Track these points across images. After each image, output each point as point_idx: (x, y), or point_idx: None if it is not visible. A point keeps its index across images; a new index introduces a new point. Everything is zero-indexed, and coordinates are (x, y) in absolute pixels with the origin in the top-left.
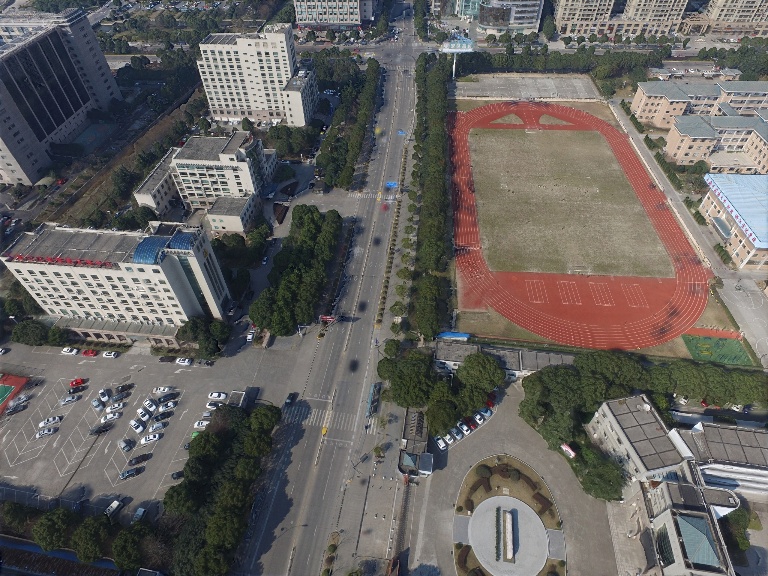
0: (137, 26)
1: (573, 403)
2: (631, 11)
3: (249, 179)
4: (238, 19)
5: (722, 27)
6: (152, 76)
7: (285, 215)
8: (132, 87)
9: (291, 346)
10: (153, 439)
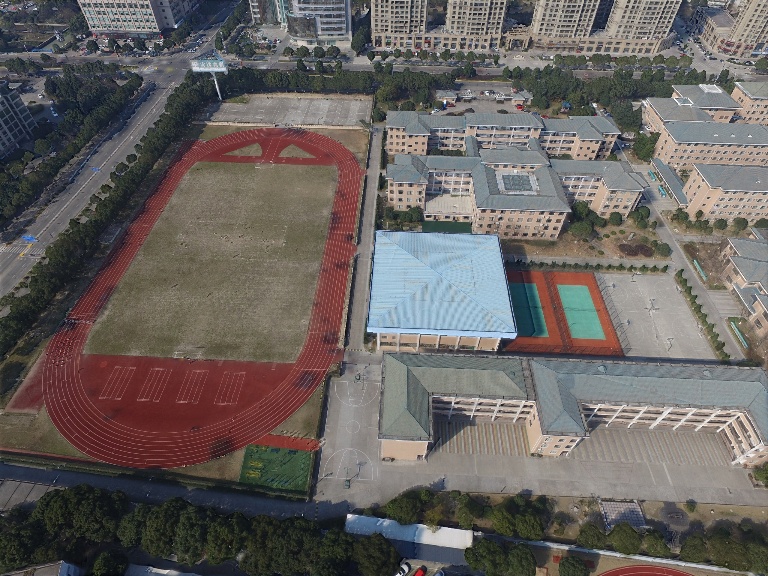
0: None
1: None
2: (448, 23)
3: None
4: (31, 24)
5: (544, 42)
6: None
7: None
8: None
9: None
10: None
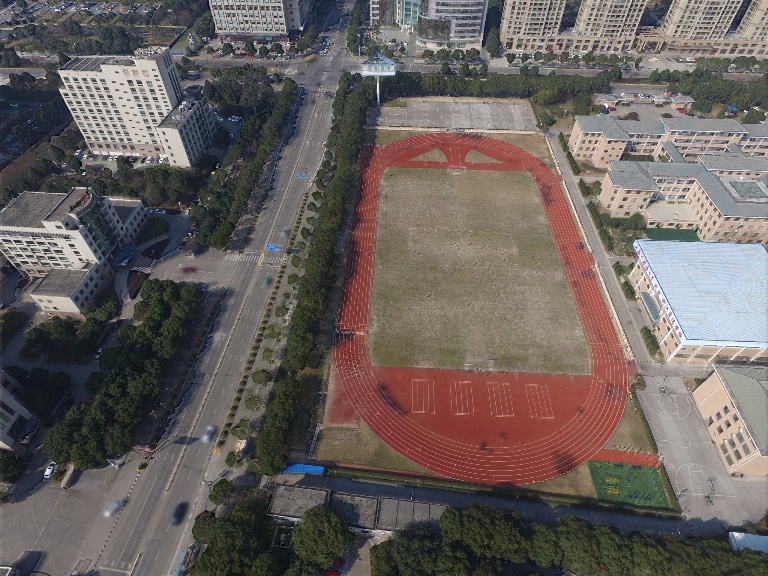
0: (36, 33)
1: None
2: (581, 25)
3: (87, 248)
4: (153, 26)
5: (678, 44)
6: (33, 97)
7: None
8: (8, 110)
9: (100, 484)
10: None
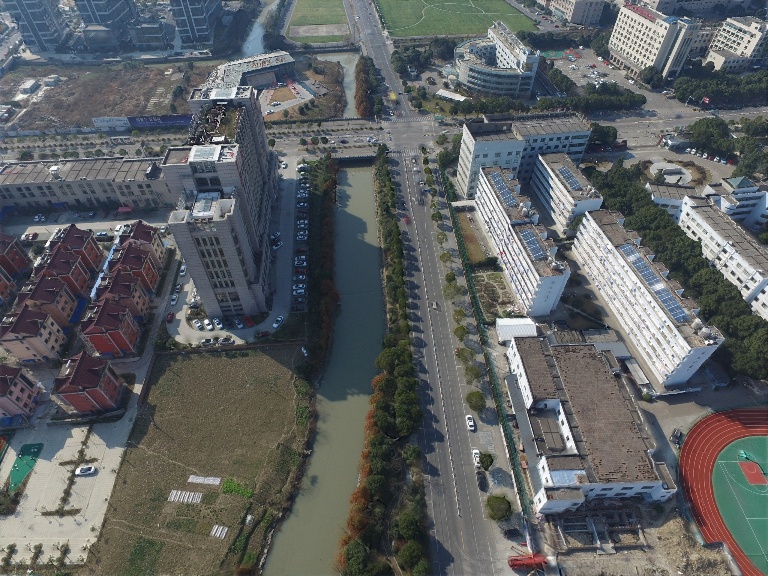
0: None
1: (767, 164)
2: None
3: (754, 46)
4: None
5: None
6: None
7: None
8: None
9: (677, 104)
10: (597, 86)
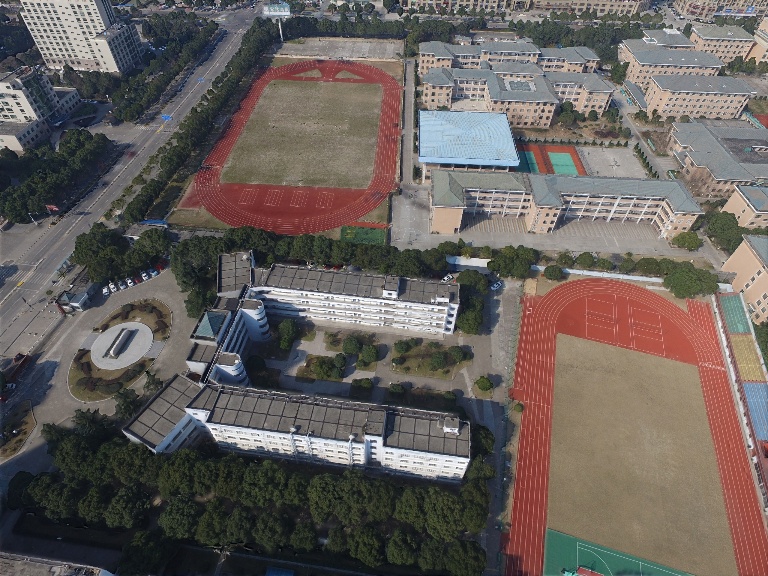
0: None
1: (199, 257)
2: None
3: (29, 106)
4: None
5: (542, 4)
6: (6, 31)
7: None
8: None
9: (24, 230)
10: None
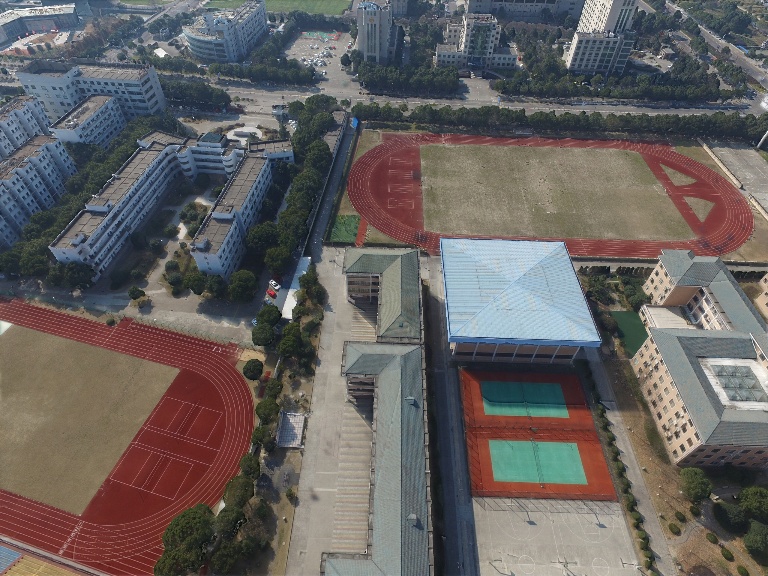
0: None
1: (293, 134)
2: None
3: (464, 42)
4: None
5: None
6: None
7: (461, 77)
8: None
9: (353, 86)
10: None
